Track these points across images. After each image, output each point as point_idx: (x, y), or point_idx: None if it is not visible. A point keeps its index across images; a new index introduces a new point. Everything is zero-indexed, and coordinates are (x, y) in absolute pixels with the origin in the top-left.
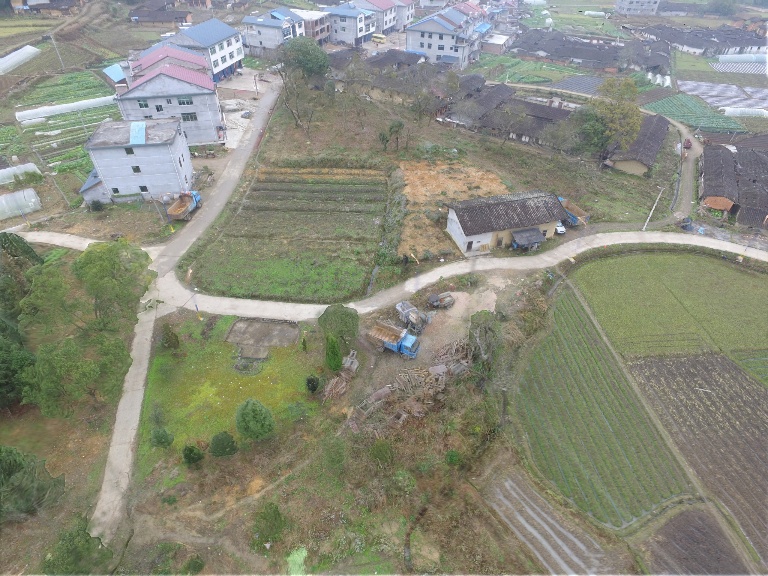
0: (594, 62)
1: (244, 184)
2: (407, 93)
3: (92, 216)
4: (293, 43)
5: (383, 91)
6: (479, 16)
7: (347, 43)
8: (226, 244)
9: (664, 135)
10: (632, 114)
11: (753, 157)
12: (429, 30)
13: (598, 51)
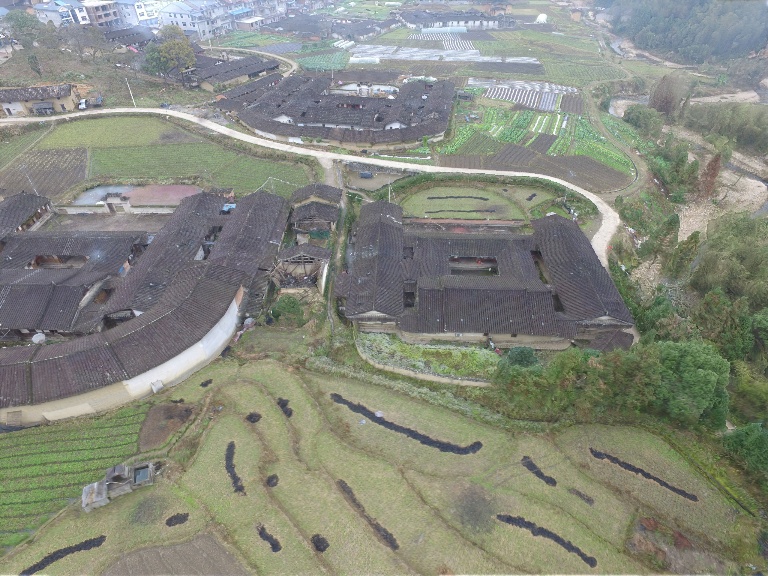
0: (305, 33)
1: None
2: (46, 39)
3: None
4: (7, 14)
5: (97, 50)
6: (237, 2)
7: (133, 25)
8: None
9: (259, 70)
10: (174, 47)
11: (288, 78)
12: (173, 11)
13: (316, 26)
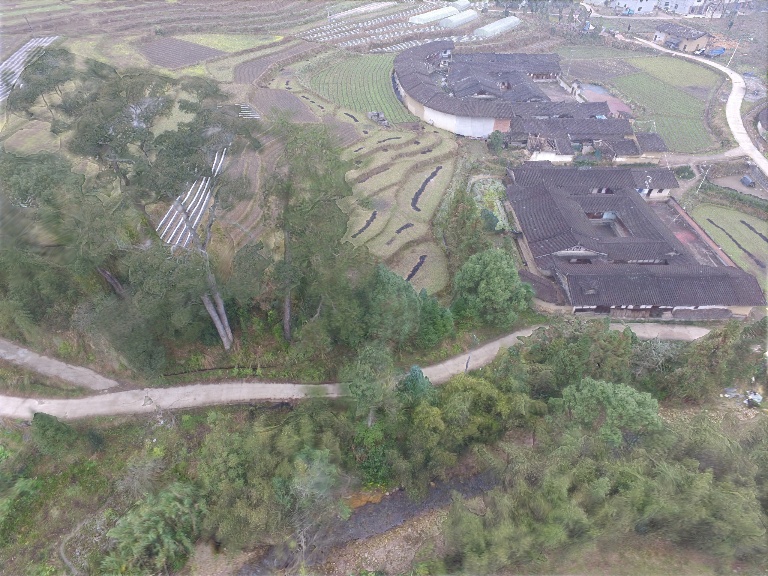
0: None
1: (655, 19)
2: None
3: (604, 7)
4: None
5: None
6: None
7: None
8: None
9: None
10: None
11: None
12: None
13: None
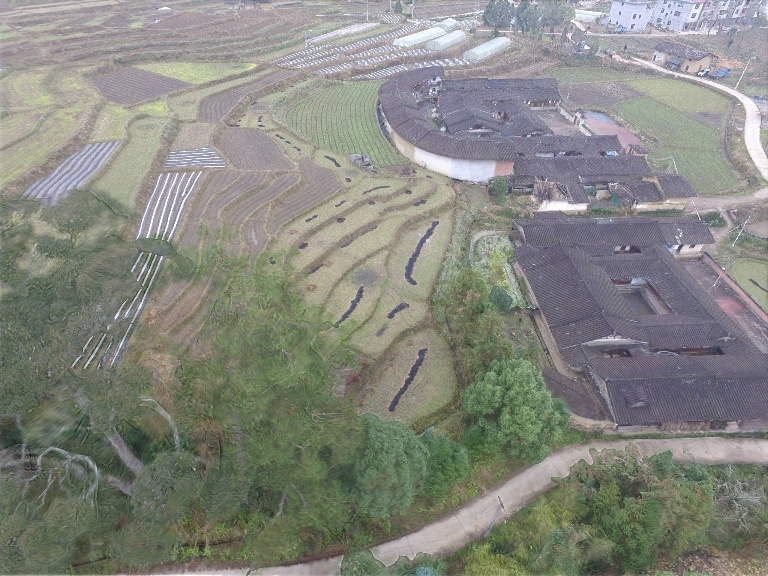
0: None
1: (650, 37)
2: None
3: None
4: None
5: None
6: None
7: None
8: (606, 39)
9: None
10: None
11: None
12: None
13: None
